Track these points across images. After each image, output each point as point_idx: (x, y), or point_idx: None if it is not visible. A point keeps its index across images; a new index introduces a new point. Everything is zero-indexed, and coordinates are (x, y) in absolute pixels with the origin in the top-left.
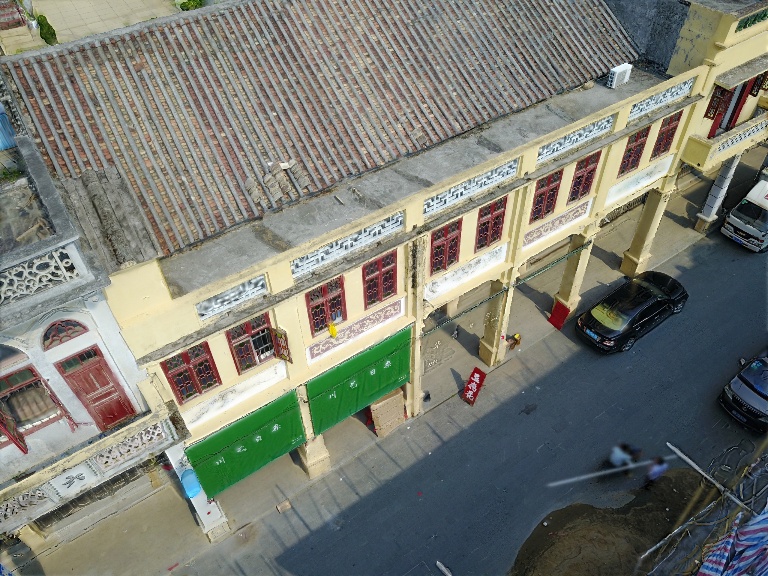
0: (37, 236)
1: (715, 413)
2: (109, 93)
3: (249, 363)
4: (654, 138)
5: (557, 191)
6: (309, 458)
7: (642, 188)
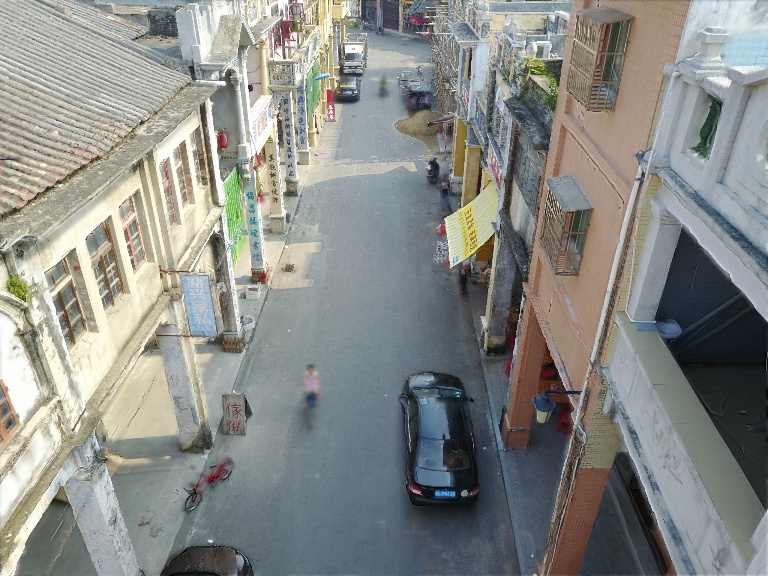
0: None
1: (403, 99)
2: None
3: None
4: None
5: None
6: (313, 128)
7: (329, 28)
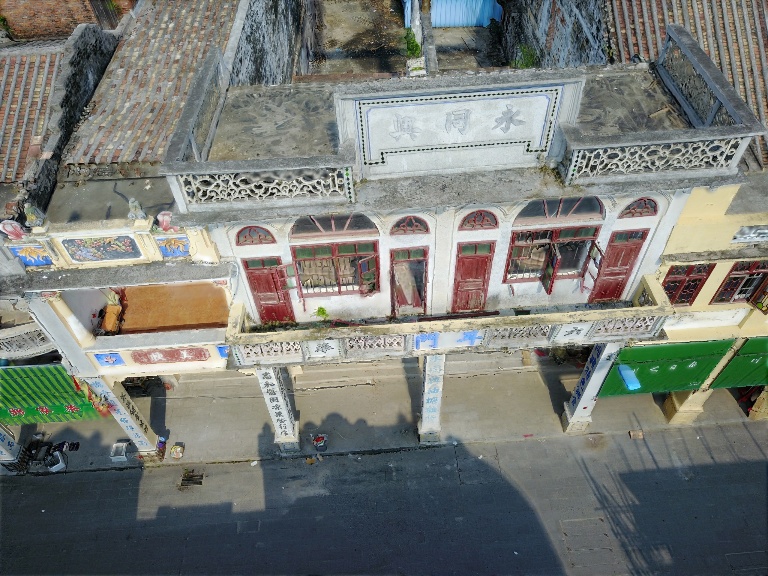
0: (669, 119)
1: None
2: (684, 1)
3: (725, 297)
4: None
5: None
6: (684, 405)
7: None
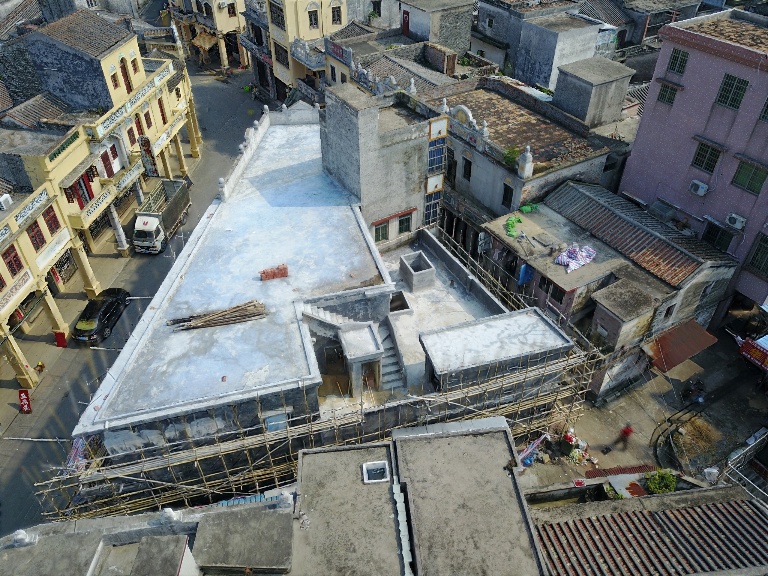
0: None
1: None
2: None
3: None
4: (44, 225)
5: None
6: None
7: (59, 251)
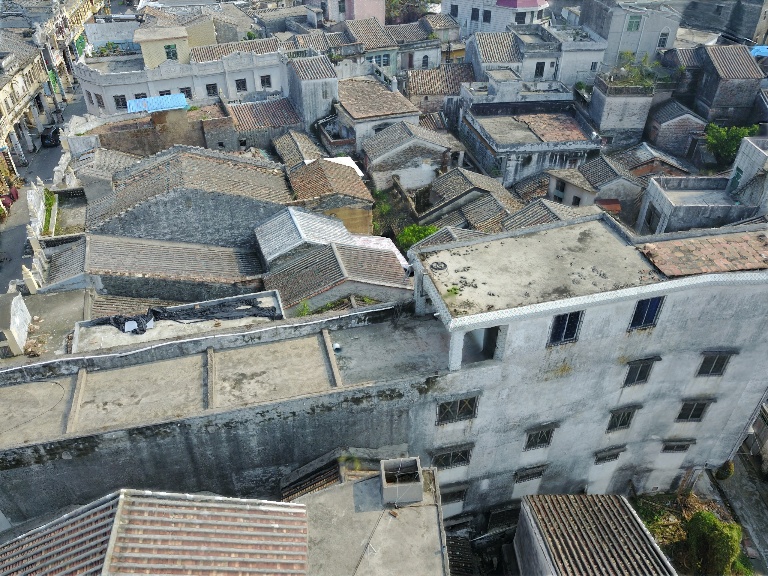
0: None
1: None
2: (20, 2)
3: None
4: (87, 5)
5: None
6: None
7: None
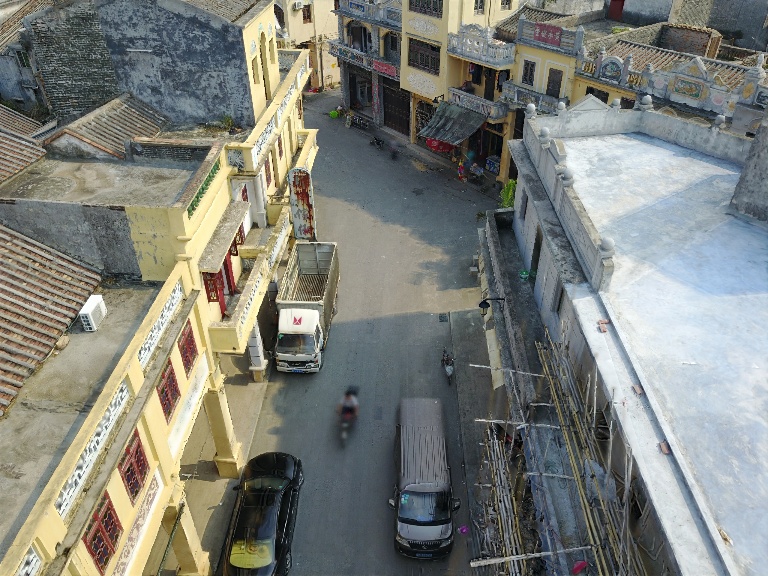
0: None
1: (404, 566)
2: None
3: None
4: (178, 358)
5: (112, 509)
6: None
7: (197, 406)
